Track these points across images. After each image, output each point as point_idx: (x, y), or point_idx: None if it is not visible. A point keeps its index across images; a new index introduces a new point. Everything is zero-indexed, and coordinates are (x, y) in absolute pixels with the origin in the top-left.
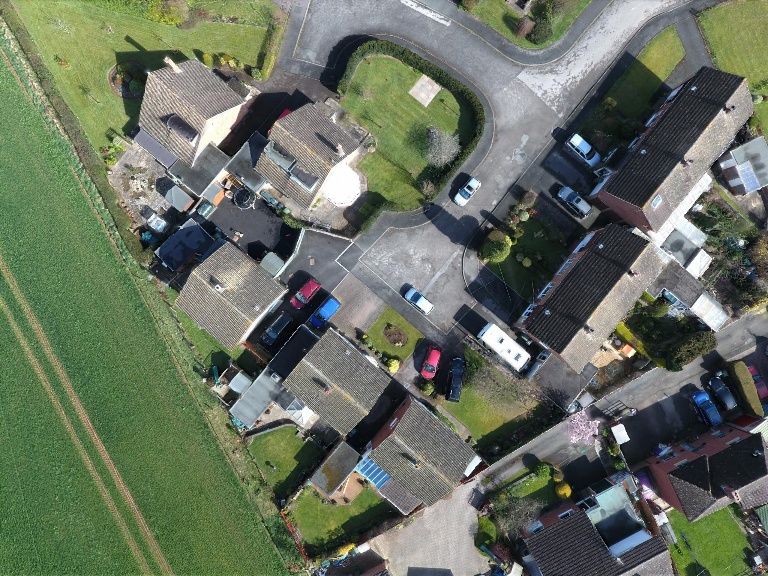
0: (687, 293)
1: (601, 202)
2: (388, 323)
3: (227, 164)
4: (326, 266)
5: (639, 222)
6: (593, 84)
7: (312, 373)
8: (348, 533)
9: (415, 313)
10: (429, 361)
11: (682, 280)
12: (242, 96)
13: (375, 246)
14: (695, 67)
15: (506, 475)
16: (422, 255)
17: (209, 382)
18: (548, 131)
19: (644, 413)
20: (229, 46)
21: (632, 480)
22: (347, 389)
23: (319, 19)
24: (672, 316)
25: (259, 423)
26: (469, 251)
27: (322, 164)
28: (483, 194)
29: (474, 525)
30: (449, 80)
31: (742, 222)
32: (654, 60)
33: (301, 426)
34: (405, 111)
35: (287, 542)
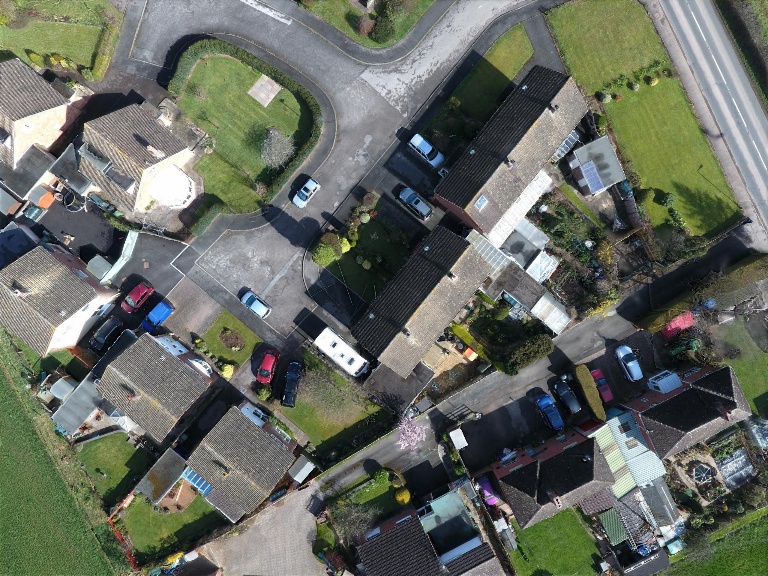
0: (527, 295)
1: (440, 203)
2: (225, 327)
3: (51, 166)
4: (161, 269)
5: (473, 224)
6: (439, 83)
7: (119, 379)
8: (181, 541)
9: (253, 317)
10: (263, 366)
11: (522, 282)
12: (66, 97)
13: (212, 249)
14: (544, 66)
15: (346, 481)
16: (261, 258)
17: (34, 388)
18: (392, 131)
19: (489, 417)
20: (62, 46)
21: (471, 486)
22: (156, 395)
23: (156, 18)
24: (518, 319)
25: (90, 429)
26: (309, 253)
27: (134, 166)
28: (324, 195)
29: (312, 532)
30: (284, 80)
31: (588, 223)
32: (501, 59)
33: (134, 432)
34: (244, 111)
35: (117, 550)
